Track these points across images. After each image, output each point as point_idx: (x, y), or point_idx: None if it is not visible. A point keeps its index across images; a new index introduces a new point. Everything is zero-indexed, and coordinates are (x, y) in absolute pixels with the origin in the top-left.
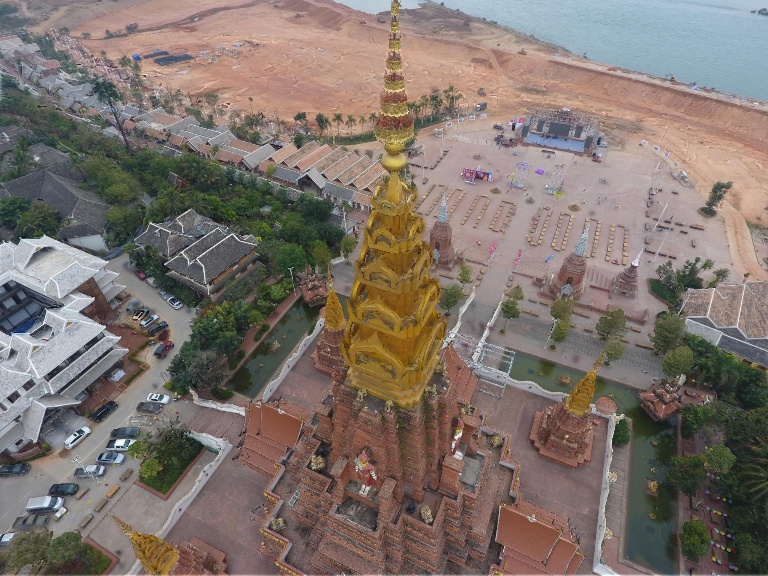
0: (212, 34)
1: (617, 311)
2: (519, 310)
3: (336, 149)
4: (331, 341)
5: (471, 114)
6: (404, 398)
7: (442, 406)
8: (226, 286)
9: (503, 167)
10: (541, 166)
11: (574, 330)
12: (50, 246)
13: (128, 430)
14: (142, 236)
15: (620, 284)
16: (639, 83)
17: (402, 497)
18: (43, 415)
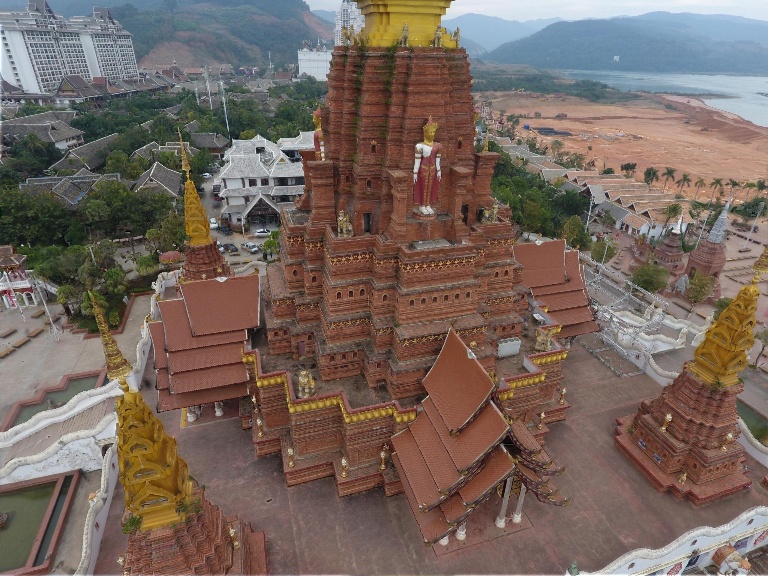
0: (604, 127)
1: None
2: None
3: None
4: None
5: None
6: None
7: None
8: None
9: None
10: None
11: None
12: None
13: None
14: None
15: None
16: None
17: None
18: (257, 201)
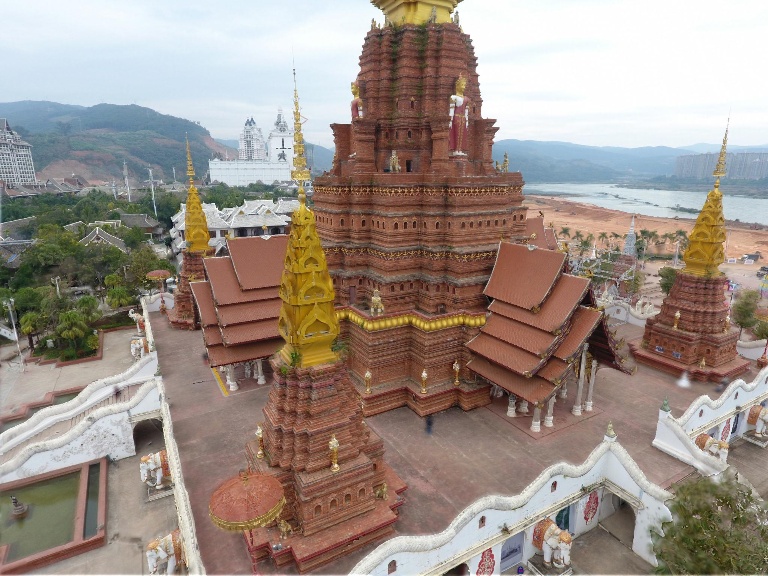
0: None
1: None
2: None
3: None
4: None
5: None
6: None
7: (440, 41)
8: None
9: None
10: None
11: None
12: None
13: None
14: None
15: None
16: None
17: None
18: (218, 250)
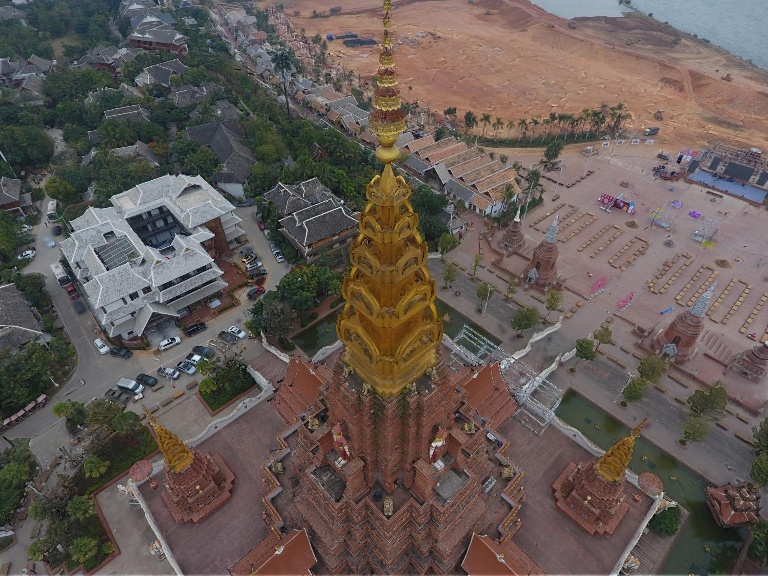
0: (401, 23)
1: (719, 389)
2: (605, 355)
3: (471, 148)
4: None
5: (636, 137)
6: (383, 387)
7: (421, 408)
8: (320, 252)
9: (651, 201)
10: (699, 209)
11: (662, 395)
12: (199, 185)
13: (206, 350)
14: (270, 192)
15: (743, 362)
16: None
17: (373, 482)
18: (149, 317)
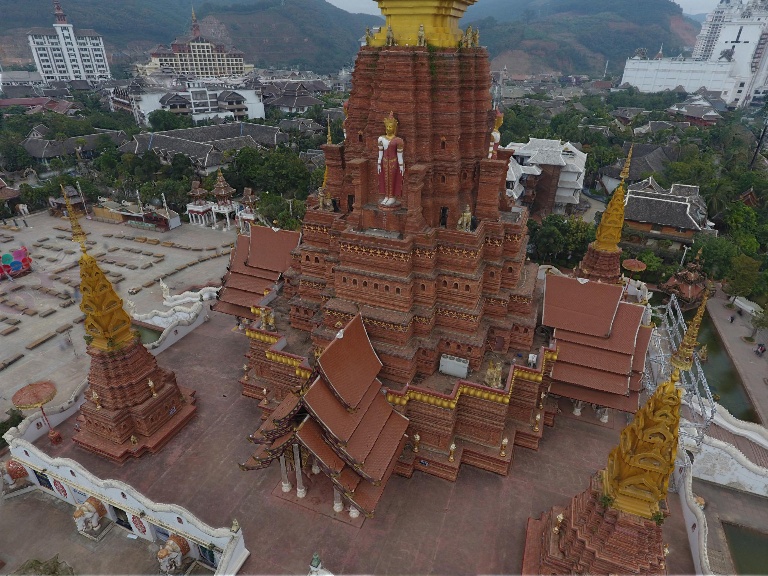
0: None
1: None
2: None
3: None
4: None
5: None
6: None
7: None
8: None
9: None
10: None
11: None
12: None
13: None
14: (635, 184)
15: None
16: None
17: None
18: None
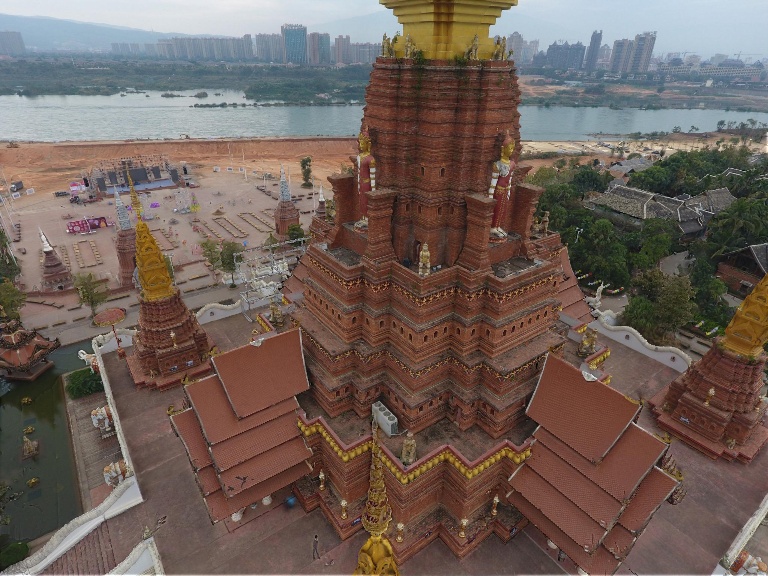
0: None
1: None
2: None
3: None
4: (169, 320)
5: (9, 195)
6: None
7: None
8: None
9: (110, 214)
10: None
11: None
12: None
13: None
14: None
15: None
16: (164, 144)
17: None
18: None
